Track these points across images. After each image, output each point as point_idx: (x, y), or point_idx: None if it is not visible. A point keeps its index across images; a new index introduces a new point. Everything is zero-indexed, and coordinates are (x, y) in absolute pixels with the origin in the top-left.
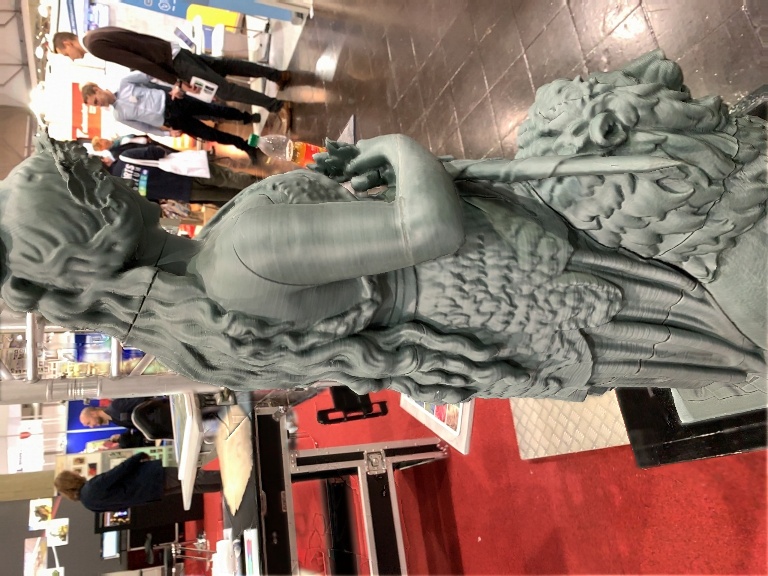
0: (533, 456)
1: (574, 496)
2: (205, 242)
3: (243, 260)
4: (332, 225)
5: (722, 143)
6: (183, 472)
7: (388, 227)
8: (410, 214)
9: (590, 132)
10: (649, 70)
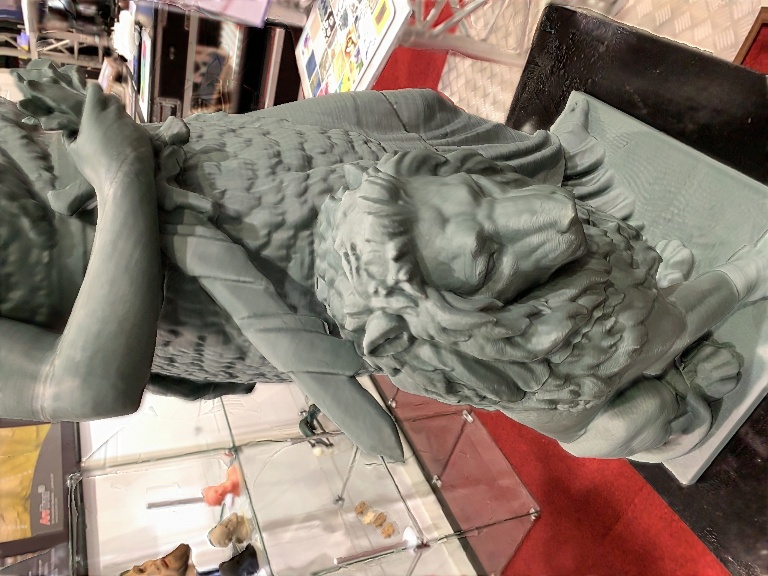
0: (448, 95)
1: None
2: None
3: None
4: None
5: (523, 382)
6: None
7: (22, 407)
8: (54, 400)
9: (367, 324)
10: (526, 242)
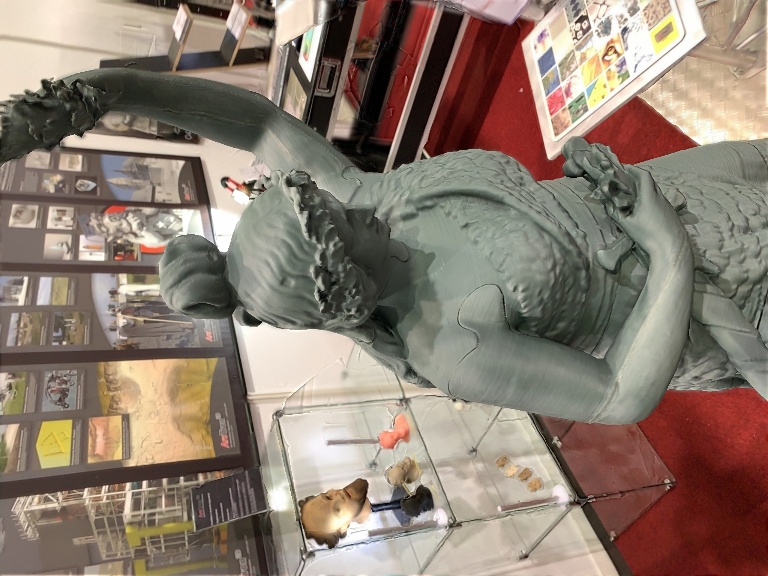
0: None
1: (622, 134)
2: (423, 295)
3: (451, 392)
4: (541, 399)
5: None
6: (281, 10)
7: (585, 413)
8: (611, 411)
9: None
10: None
